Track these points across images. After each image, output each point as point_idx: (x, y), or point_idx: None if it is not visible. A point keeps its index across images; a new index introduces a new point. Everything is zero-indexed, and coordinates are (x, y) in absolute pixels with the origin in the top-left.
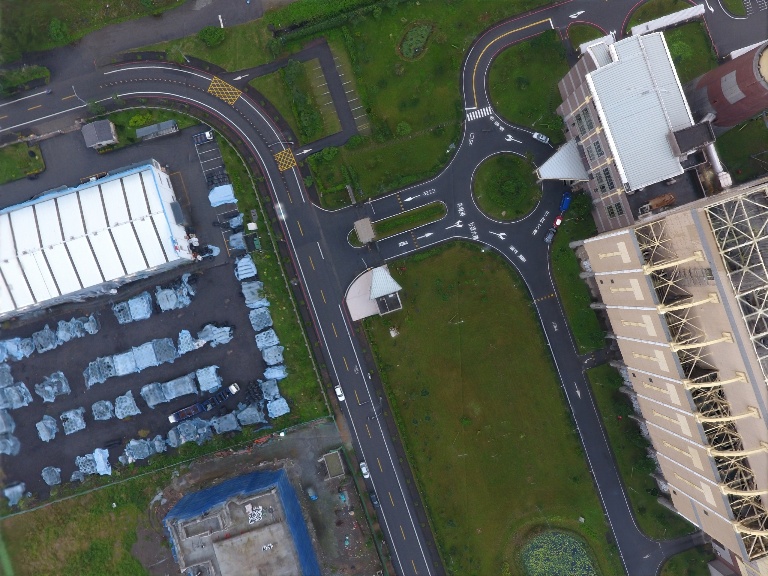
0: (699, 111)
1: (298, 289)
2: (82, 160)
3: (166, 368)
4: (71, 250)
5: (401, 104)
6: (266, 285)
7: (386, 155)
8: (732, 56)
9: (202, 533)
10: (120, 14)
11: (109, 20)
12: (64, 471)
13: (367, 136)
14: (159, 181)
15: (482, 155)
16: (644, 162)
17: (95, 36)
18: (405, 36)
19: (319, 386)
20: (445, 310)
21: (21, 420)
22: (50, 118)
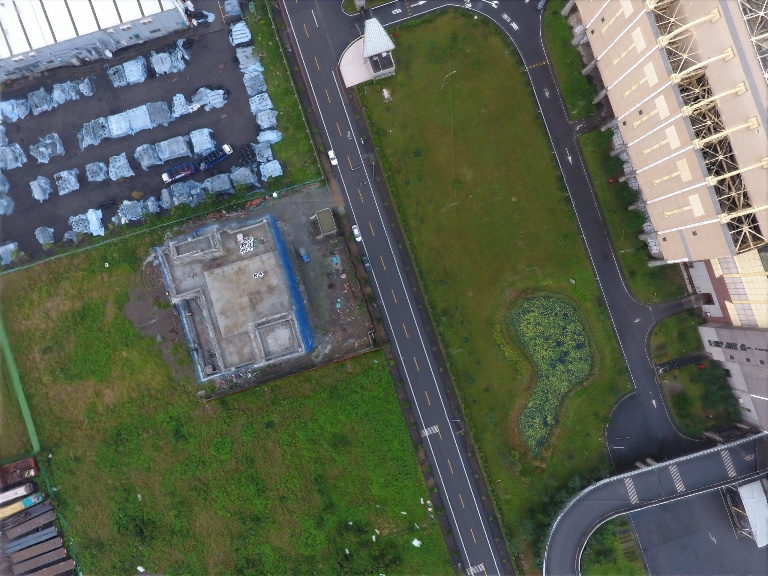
0: None
1: (292, 56)
2: None
3: (160, 131)
4: None
5: None
6: (260, 51)
7: None
8: None
9: (193, 251)
10: None
11: None
12: (57, 231)
13: None
14: None
15: None
16: None
17: None
18: None
19: (312, 148)
20: (438, 76)
21: (15, 181)
22: None
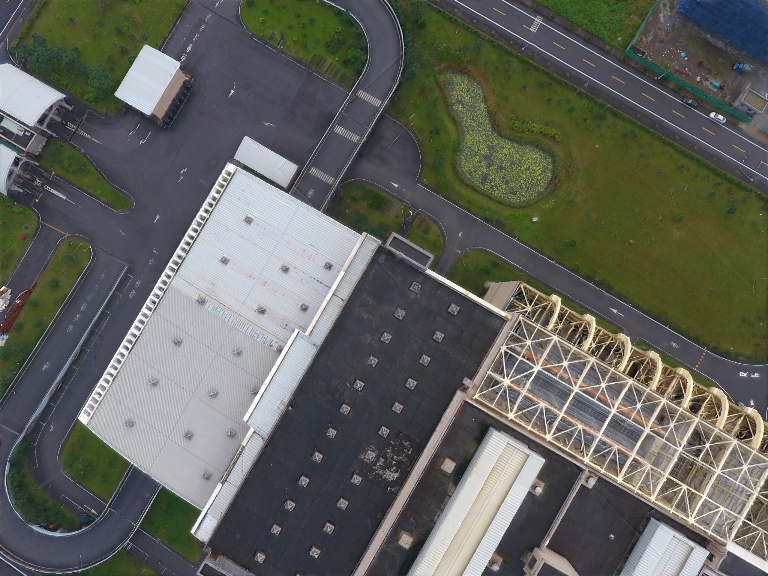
0: None
1: None
2: None
3: None
4: None
5: None
6: None
7: None
8: None
9: None
10: None
11: None
12: None
13: None
14: None
15: None
16: None
17: None
18: None
19: None
20: (765, 285)
21: None
22: None
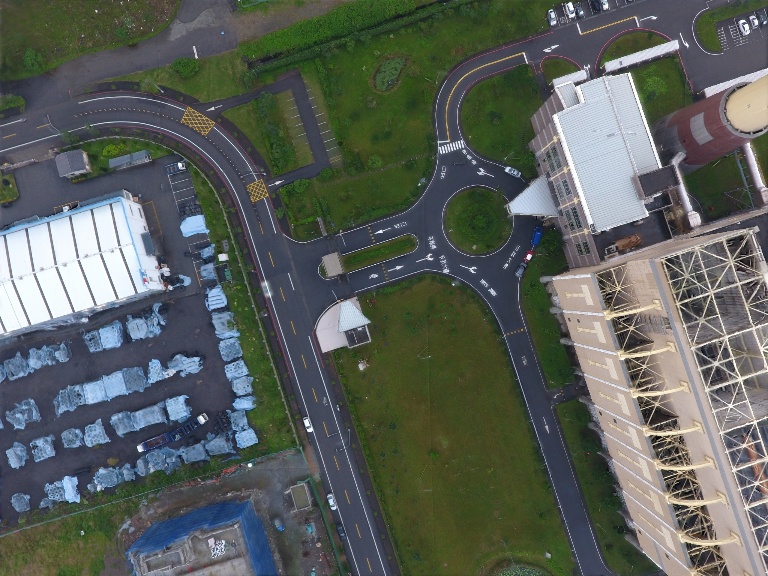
0: (670, 149)
1: (268, 320)
2: (56, 189)
3: (136, 397)
4: (41, 281)
5: (373, 137)
6: (236, 316)
7: (358, 187)
8: (706, 93)
9: (163, 568)
10: (95, 44)
11: (84, 50)
12: (33, 498)
13: (339, 168)
14: (129, 212)
15: (454, 188)
16: (609, 204)
17: (70, 65)
18: (378, 68)
19: (287, 417)
20: (414, 343)
21: None
22: (25, 146)
